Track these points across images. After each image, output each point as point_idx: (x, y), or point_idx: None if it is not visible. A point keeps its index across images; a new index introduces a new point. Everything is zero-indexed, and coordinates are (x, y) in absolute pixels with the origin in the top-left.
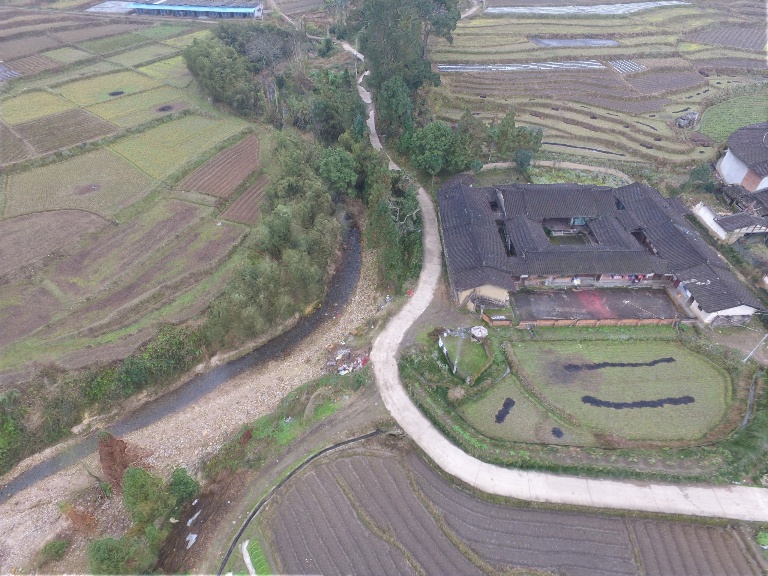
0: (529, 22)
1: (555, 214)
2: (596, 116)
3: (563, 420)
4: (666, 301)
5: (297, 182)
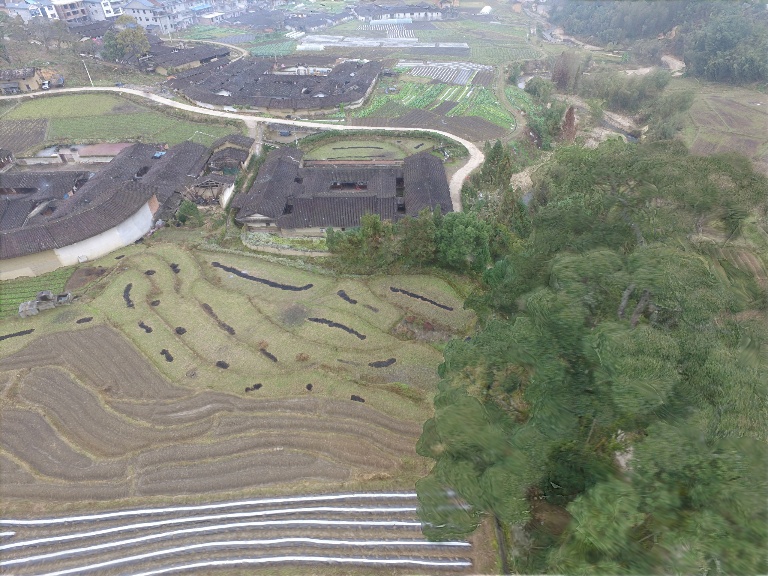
0: None
1: None
2: (174, 330)
3: None
4: None
5: (592, 197)
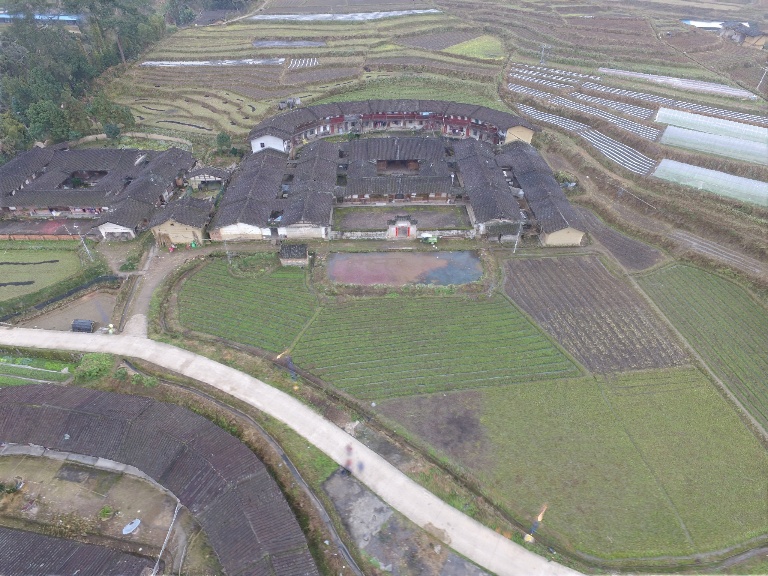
0: (273, 27)
1: (81, 168)
2: (227, 101)
3: None
4: None
5: None
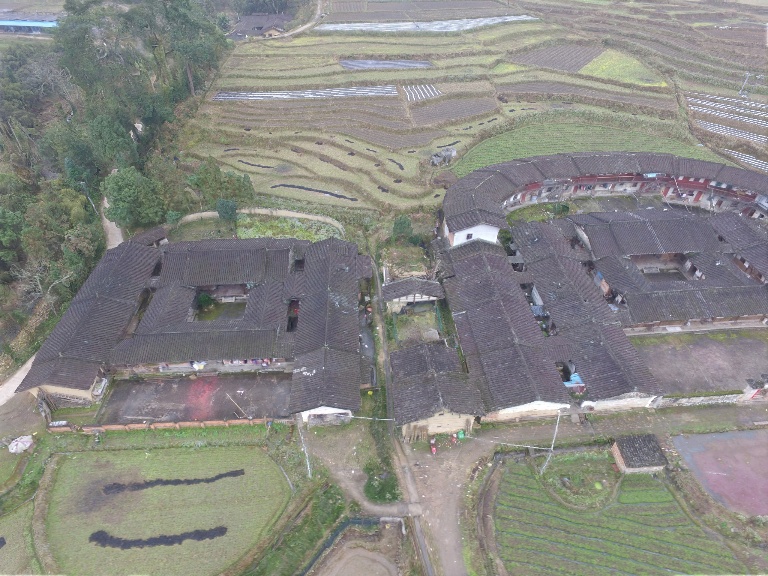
0: (353, 41)
1: (213, 280)
2: (354, 152)
3: (43, 570)
4: (287, 390)
5: None
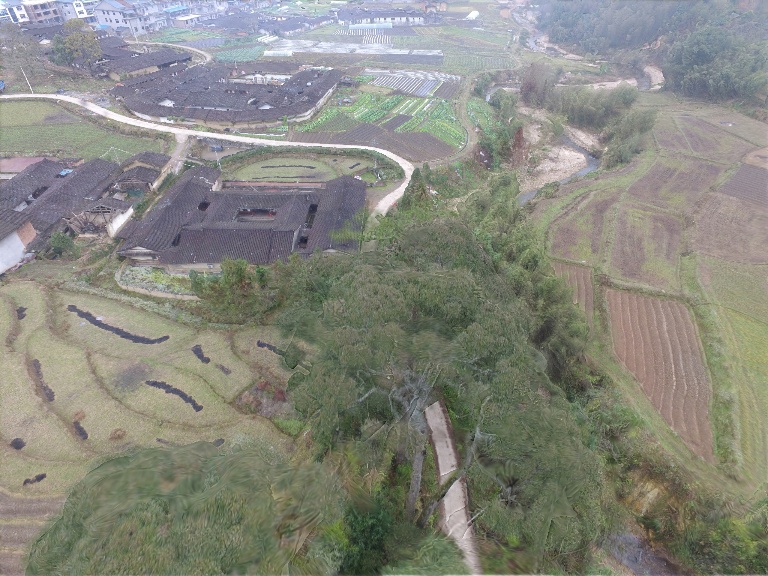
0: None
1: (256, 223)
2: None
3: None
4: None
5: (509, 235)
